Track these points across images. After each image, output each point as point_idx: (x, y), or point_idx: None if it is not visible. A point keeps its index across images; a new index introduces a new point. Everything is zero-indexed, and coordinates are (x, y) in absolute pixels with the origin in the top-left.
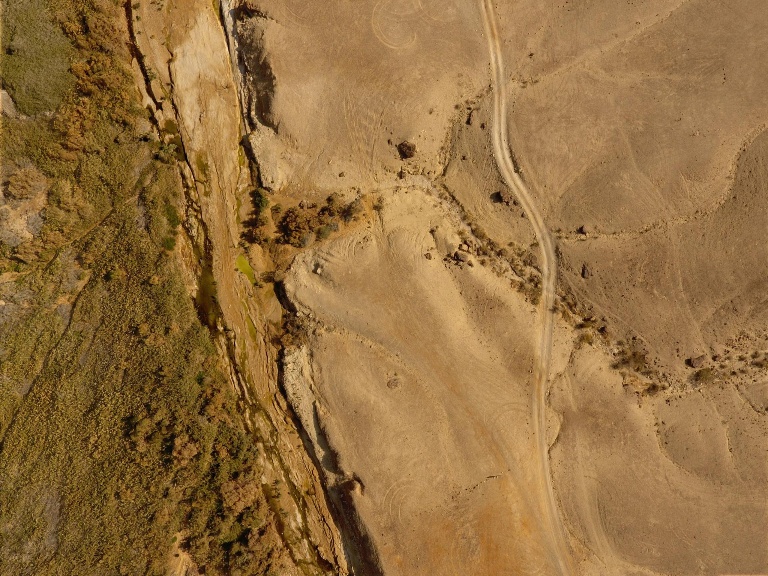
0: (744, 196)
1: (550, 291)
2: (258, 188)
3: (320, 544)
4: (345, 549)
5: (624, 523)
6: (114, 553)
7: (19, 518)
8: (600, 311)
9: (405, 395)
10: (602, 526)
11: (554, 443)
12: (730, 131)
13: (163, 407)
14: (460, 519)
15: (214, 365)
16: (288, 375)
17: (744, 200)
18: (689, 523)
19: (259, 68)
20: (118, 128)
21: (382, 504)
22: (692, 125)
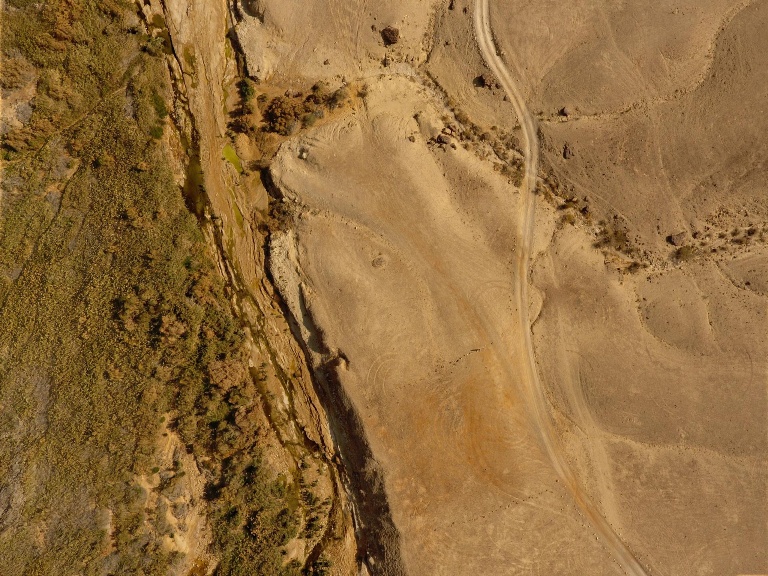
0: (723, 74)
1: (532, 174)
2: (244, 78)
3: (307, 425)
4: (331, 429)
5: (605, 393)
6: (103, 431)
7: (10, 399)
8: (582, 191)
9: (389, 273)
10: (584, 398)
11: (536, 319)
12: (708, 10)
13: (151, 288)
14: (444, 391)
15: (201, 250)
16: (274, 259)
17: (723, 78)
18: (670, 392)
19: None
20: (106, 20)
21: (367, 378)
22: (671, 3)
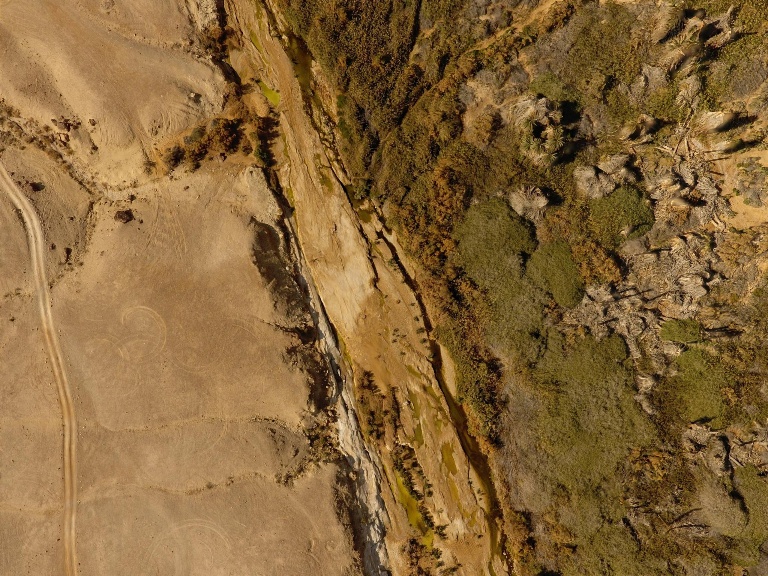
0: None
1: None
2: (267, 167)
3: None
4: None
5: None
6: None
7: None
8: None
9: None
10: None
11: None
12: None
13: None
14: None
15: (280, 0)
16: (211, 2)
17: None
18: None
19: (277, 276)
20: None
21: None
22: None
